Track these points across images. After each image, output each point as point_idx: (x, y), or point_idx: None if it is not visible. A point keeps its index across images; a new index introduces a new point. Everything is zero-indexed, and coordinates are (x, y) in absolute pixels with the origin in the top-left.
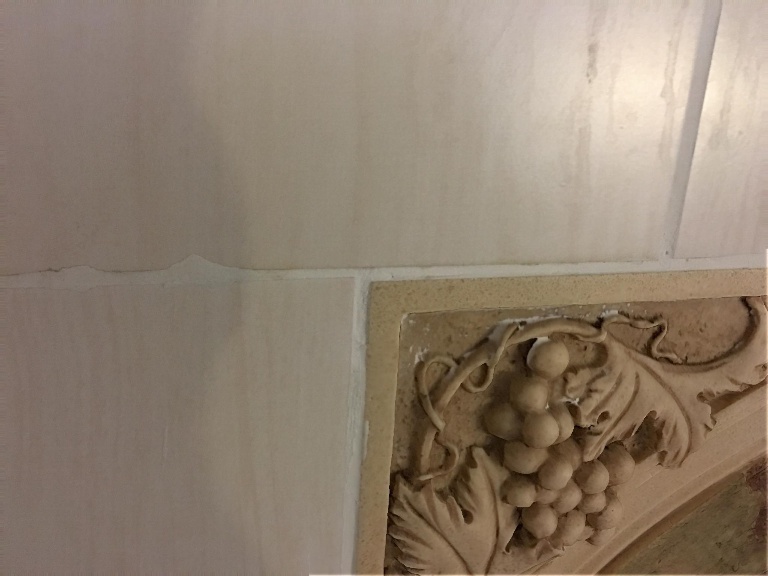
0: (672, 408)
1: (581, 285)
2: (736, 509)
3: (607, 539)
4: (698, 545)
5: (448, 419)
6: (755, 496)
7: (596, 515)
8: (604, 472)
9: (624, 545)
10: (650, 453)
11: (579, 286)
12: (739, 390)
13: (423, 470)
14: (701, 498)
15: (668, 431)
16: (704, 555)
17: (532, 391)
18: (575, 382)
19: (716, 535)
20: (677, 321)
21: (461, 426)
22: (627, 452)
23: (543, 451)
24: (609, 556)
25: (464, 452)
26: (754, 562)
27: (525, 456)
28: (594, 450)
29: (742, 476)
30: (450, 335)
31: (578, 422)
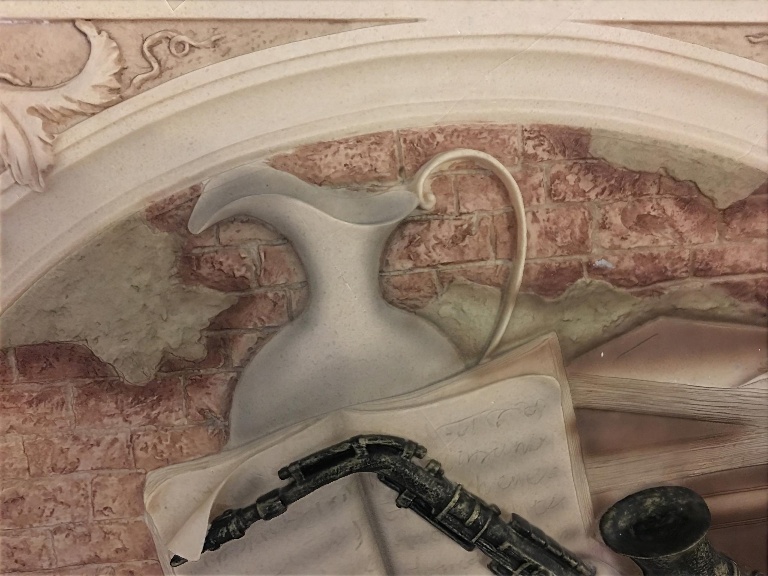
0: None
1: None
2: (143, 249)
3: None
4: (109, 285)
5: None
6: (161, 237)
7: None
8: None
9: (26, 277)
10: None
11: None
12: (80, 109)
13: None
14: None
15: None
16: (122, 298)
17: None
18: None
19: (128, 276)
20: (8, 44)
21: None
22: None
23: None
24: (13, 287)
25: None
26: (186, 313)
27: None
28: None
29: (136, 212)
30: None
31: None
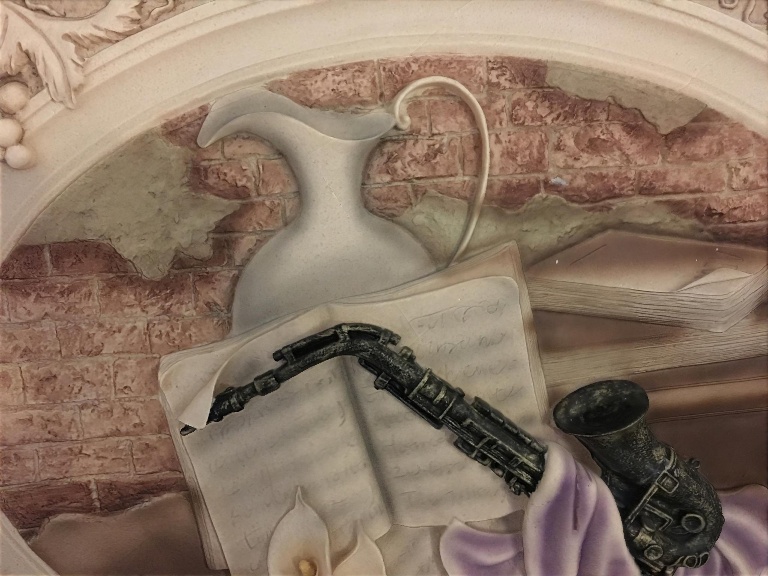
0: (38, 43)
1: None
2: (158, 160)
3: (15, 158)
4: (130, 191)
5: None
6: (174, 150)
7: None
8: None
9: (60, 183)
10: (42, 89)
11: None
12: (106, 37)
13: None
14: None
15: (39, 62)
16: (141, 203)
17: None
18: None
19: (146, 184)
20: None
21: None
22: (19, 85)
23: None
24: (48, 191)
25: None
26: (195, 217)
27: None
28: None
29: (153, 128)
30: None
31: None
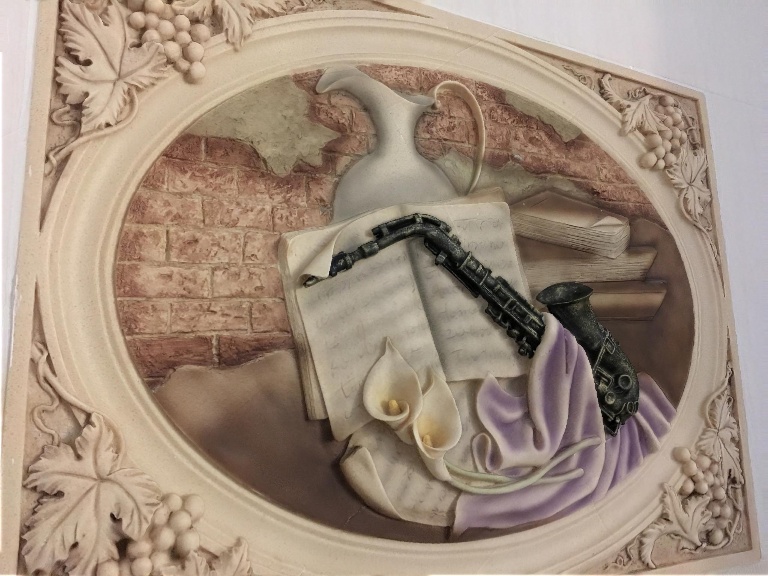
0: (225, 3)
1: None
2: (290, 96)
3: (198, 70)
4: (269, 112)
5: None
6: (301, 91)
7: (186, 47)
8: None
9: (219, 98)
10: (221, 33)
11: None
12: (268, 12)
13: None
14: None
15: (225, 14)
16: (276, 121)
17: None
18: None
19: (281, 109)
20: None
21: None
22: None
23: None
24: (210, 102)
25: (106, 1)
26: (312, 137)
27: None
28: (179, 6)
29: None
30: None
31: None
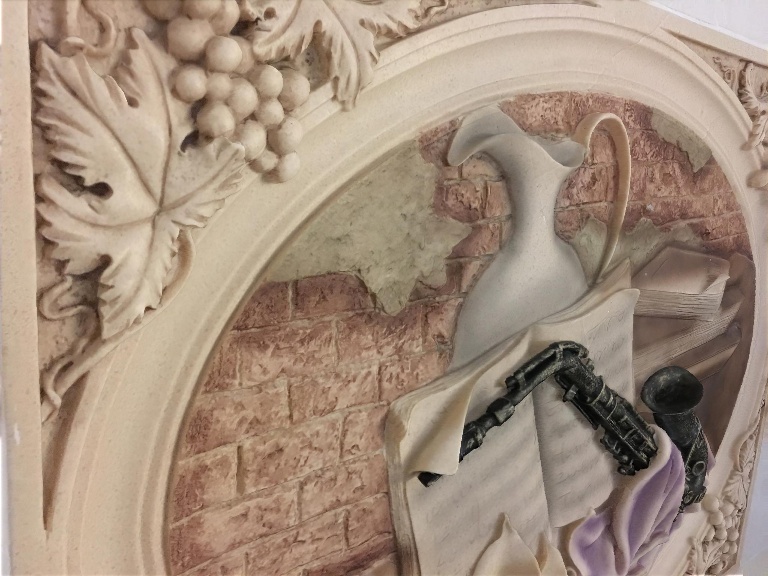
0: (337, 25)
1: None
2: (414, 178)
3: (292, 169)
4: (385, 213)
5: None
6: (429, 167)
7: (276, 129)
8: (276, 70)
9: (314, 201)
10: (324, 82)
11: None
12: (397, 31)
13: (71, 33)
14: (381, 160)
15: (336, 49)
16: (392, 226)
17: None
18: None
19: (400, 205)
20: None
21: None
22: None
23: (208, 27)
24: (301, 212)
25: (123, 35)
26: (437, 242)
27: (189, 27)
28: (264, 45)
29: (414, 141)
30: None
31: (243, 7)
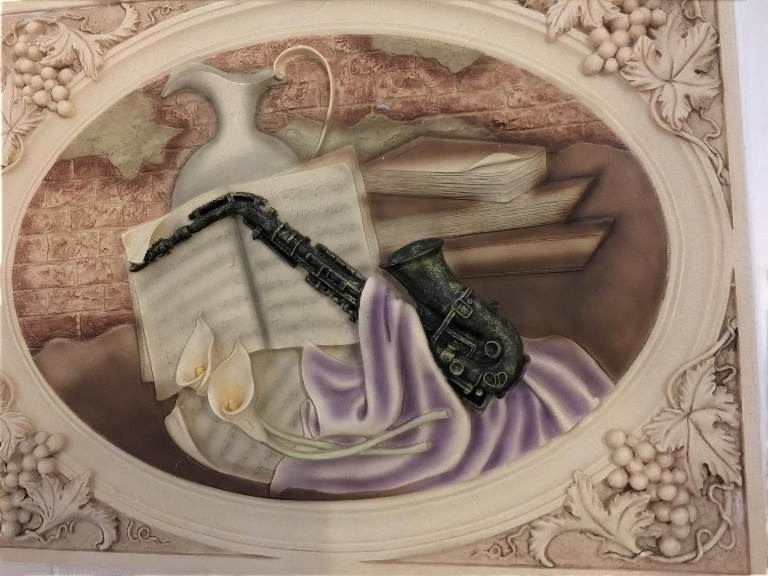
0: (81, 45)
1: (44, 1)
2: (139, 107)
3: (62, 107)
4: (121, 126)
5: (2, 58)
6: (148, 100)
7: None
8: None
9: (85, 124)
10: None
11: (43, 2)
12: (117, 40)
13: None
14: None
15: (80, 55)
16: (127, 132)
17: (20, 36)
18: (42, 37)
19: (131, 121)
20: (93, 17)
21: (7, 61)
22: (70, 69)
23: (24, 59)
24: (78, 129)
25: None
26: (156, 139)
27: None
28: (46, 60)
29: None
30: (3, 26)
31: (39, 49)
